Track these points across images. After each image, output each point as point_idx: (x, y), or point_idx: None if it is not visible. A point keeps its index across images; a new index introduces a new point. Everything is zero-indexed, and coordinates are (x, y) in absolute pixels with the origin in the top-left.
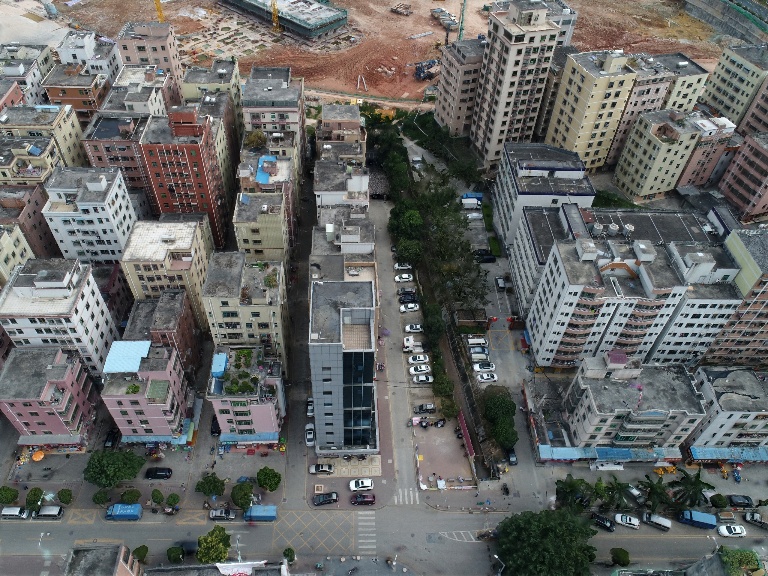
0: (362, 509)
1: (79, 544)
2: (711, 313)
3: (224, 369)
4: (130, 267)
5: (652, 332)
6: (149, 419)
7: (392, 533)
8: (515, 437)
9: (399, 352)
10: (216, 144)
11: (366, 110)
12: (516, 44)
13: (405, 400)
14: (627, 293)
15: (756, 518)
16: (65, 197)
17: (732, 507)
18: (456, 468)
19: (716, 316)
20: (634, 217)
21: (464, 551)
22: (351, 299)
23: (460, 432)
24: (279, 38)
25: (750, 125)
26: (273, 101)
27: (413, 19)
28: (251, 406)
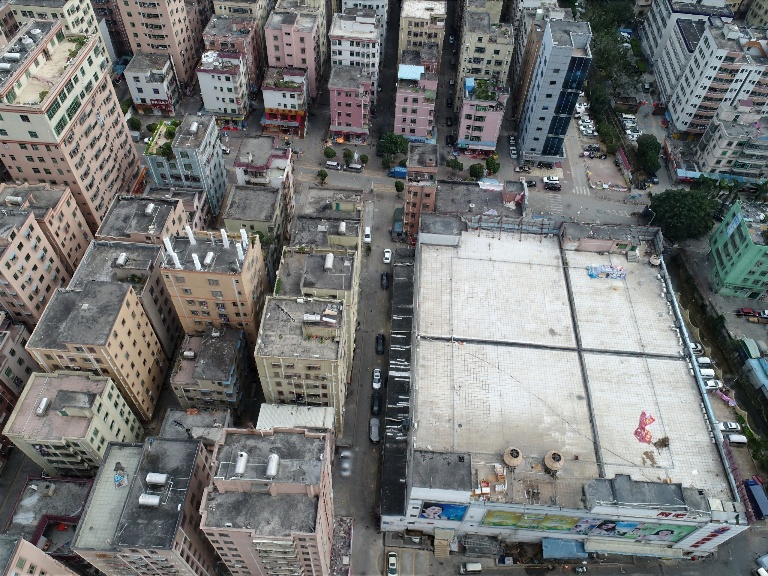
0: (552, 193)
1: (374, 186)
2: None
3: None
4: (405, 23)
5: None
6: (417, 118)
7: (573, 206)
8: (659, 164)
9: None
10: None
11: None
12: None
13: (577, 144)
14: (757, 64)
15: None
16: None
17: None
18: (615, 180)
19: None
20: None
21: (622, 220)
22: (575, 29)
23: (618, 162)
24: None
25: None
26: None
27: None
28: (488, 112)
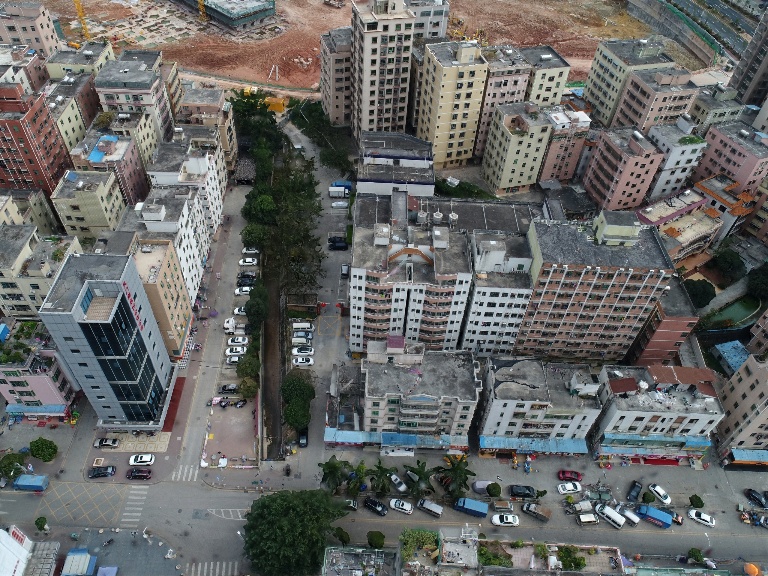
0: (136, 483)
1: None
2: (505, 302)
3: None
4: None
5: (453, 320)
6: None
7: (160, 508)
8: (306, 419)
9: (222, 333)
10: (59, 123)
11: (260, 98)
12: (369, 32)
13: (213, 380)
14: (418, 279)
15: (531, 508)
16: None
17: (512, 497)
18: (243, 448)
19: (512, 305)
20: (467, 207)
21: (227, 528)
22: (102, 272)
23: None
24: (205, 27)
25: (619, 121)
26: (125, 82)
27: (344, 12)
28: (25, 377)
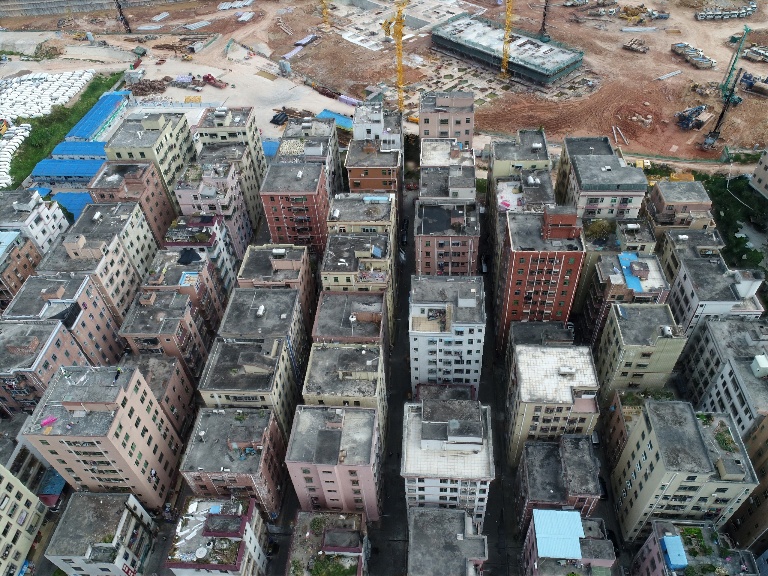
0: None
1: None
2: None
3: (685, 561)
4: (529, 408)
5: None
6: None
7: None
8: None
9: None
10: None
11: (655, 173)
12: None
13: None
14: None
15: None
16: (427, 312)
17: None
18: None
19: None
20: None
21: None
22: None
23: None
24: (508, 85)
25: None
26: (619, 184)
27: (652, 56)
28: None
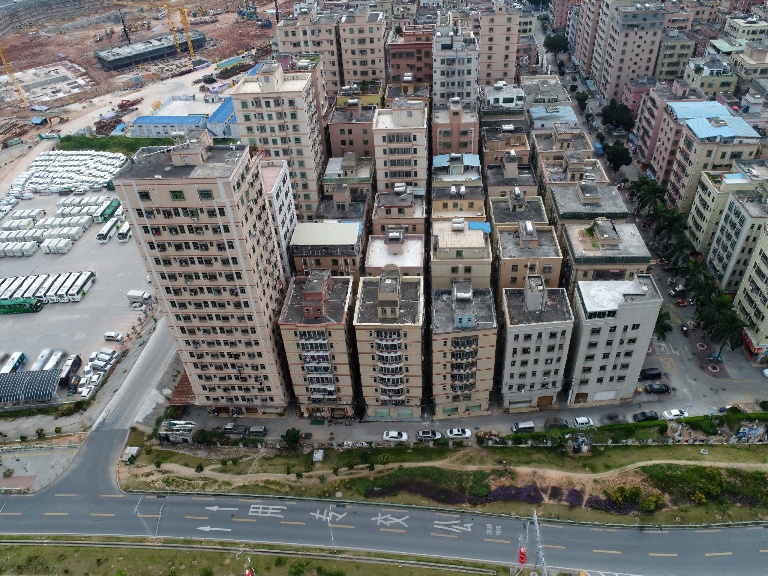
0: None
1: None
2: None
3: None
4: None
5: None
6: None
7: None
8: None
9: None
10: None
11: None
12: None
13: None
14: None
15: None
16: None
17: None
18: None
19: None
20: None
21: None
22: None
23: None
24: (189, 55)
25: None
26: None
27: None
28: None
